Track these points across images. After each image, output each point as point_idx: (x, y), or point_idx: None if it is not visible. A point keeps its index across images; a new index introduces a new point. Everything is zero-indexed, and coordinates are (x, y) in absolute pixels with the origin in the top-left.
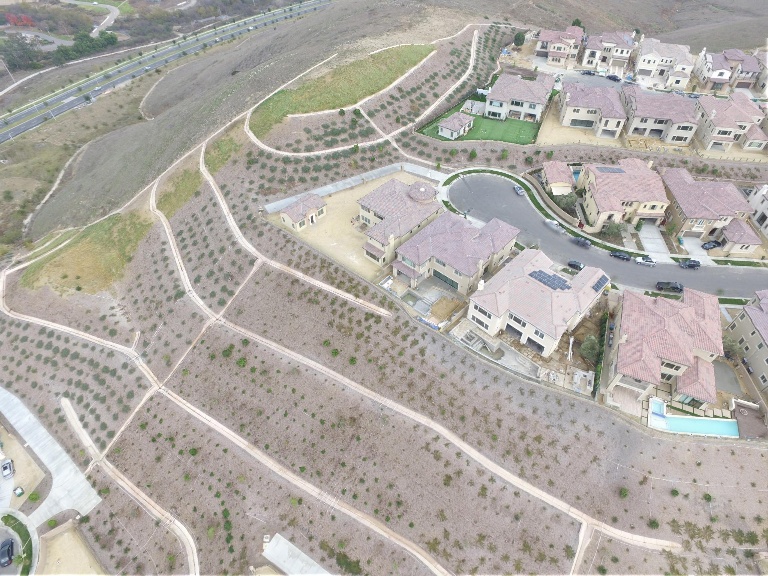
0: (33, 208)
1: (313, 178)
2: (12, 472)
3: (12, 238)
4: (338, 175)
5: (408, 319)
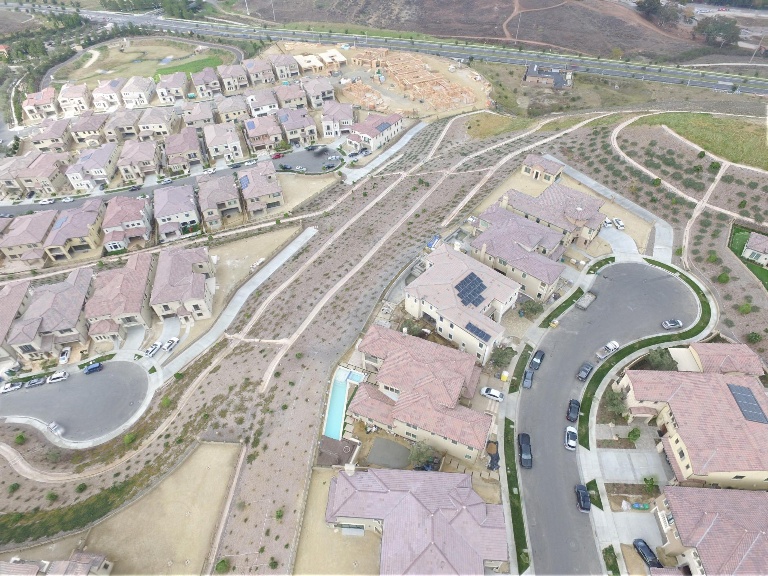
0: (568, 111)
1: (596, 169)
2: (365, 155)
3: (533, 112)
4: (613, 183)
5: (438, 232)
